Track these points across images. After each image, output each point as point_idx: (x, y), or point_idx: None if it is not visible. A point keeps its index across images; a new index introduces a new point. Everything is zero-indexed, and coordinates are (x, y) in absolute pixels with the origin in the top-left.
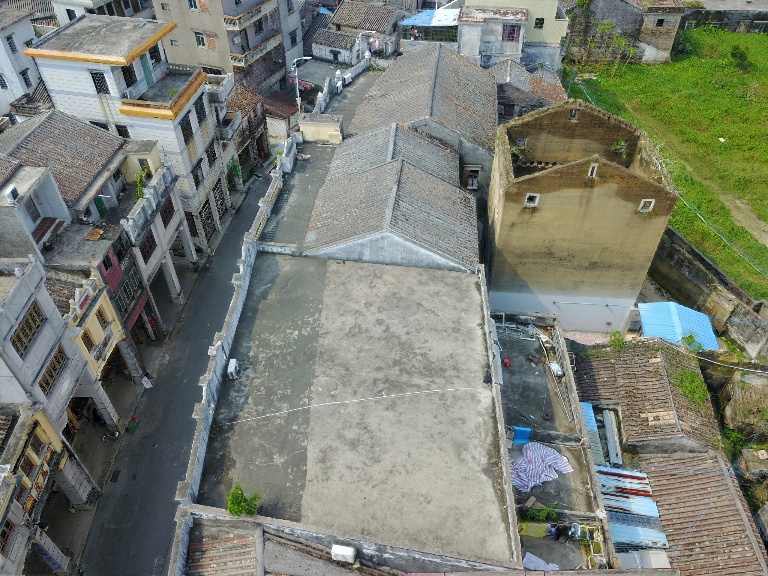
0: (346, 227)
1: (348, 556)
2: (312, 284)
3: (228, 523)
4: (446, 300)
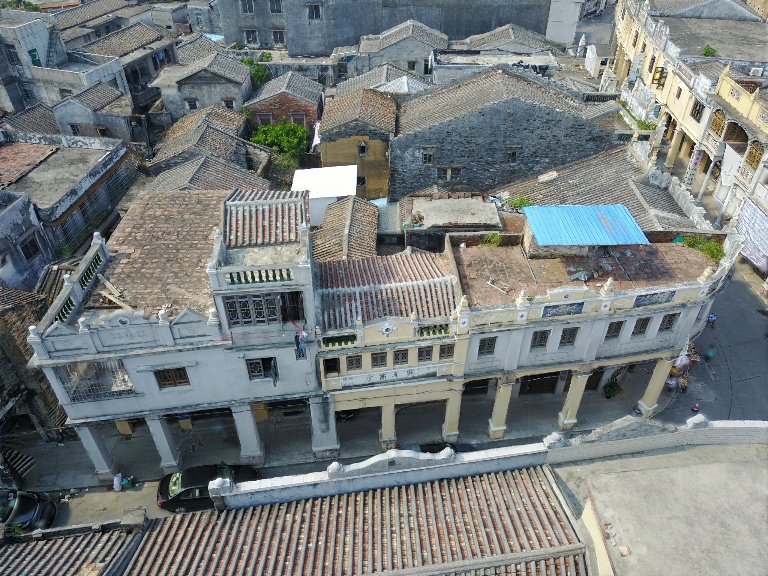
0: (690, 2)
1: (760, 70)
2: (679, 23)
3: (701, 63)
4: (755, 28)
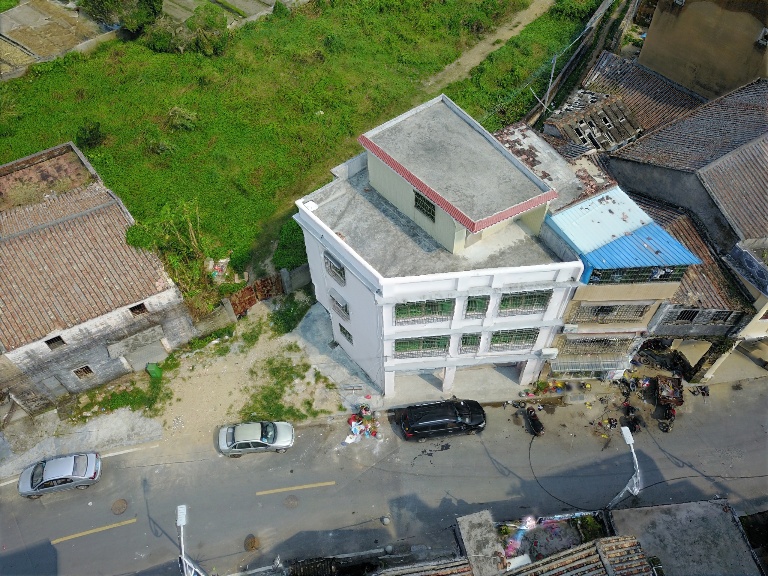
0: None
1: None
2: None
3: None
4: None
